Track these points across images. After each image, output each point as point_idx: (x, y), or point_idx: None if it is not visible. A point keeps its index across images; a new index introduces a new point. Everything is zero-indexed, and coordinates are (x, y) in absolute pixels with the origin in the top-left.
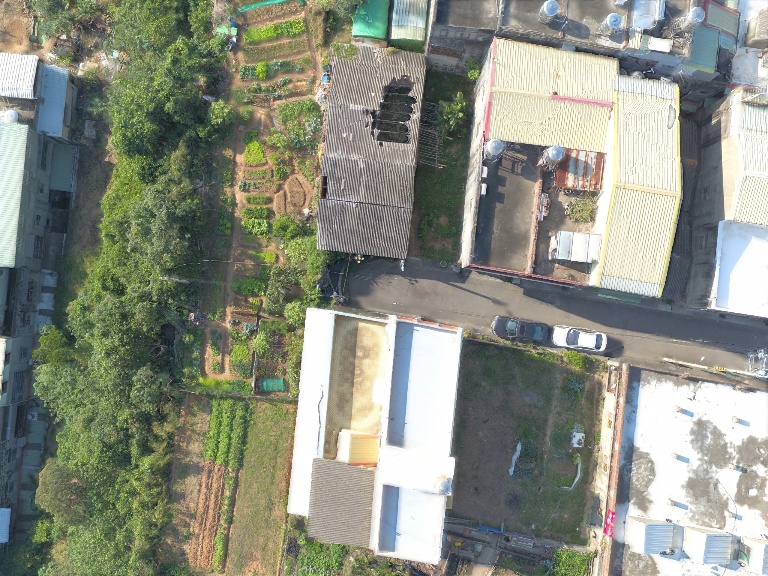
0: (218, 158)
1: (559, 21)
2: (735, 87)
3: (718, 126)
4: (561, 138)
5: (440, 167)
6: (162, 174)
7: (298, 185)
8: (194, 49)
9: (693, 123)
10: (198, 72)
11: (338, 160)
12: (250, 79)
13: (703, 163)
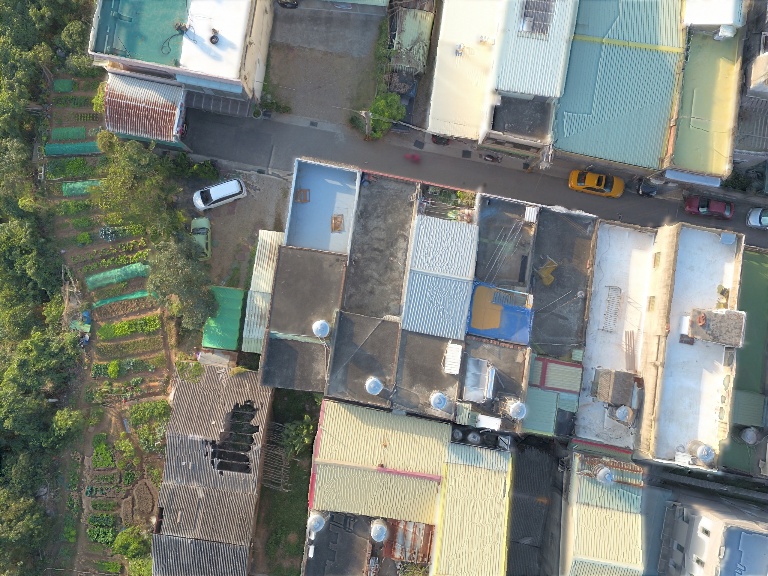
0: (66, 460)
1: (387, 389)
2: (578, 443)
3: (561, 478)
4: (387, 509)
5: (285, 491)
6: (4, 483)
7: (146, 491)
8: (44, 348)
9: (545, 454)
10: (46, 375)
11: (177, 488)
12: (102, 378)
13: (551, 504)
